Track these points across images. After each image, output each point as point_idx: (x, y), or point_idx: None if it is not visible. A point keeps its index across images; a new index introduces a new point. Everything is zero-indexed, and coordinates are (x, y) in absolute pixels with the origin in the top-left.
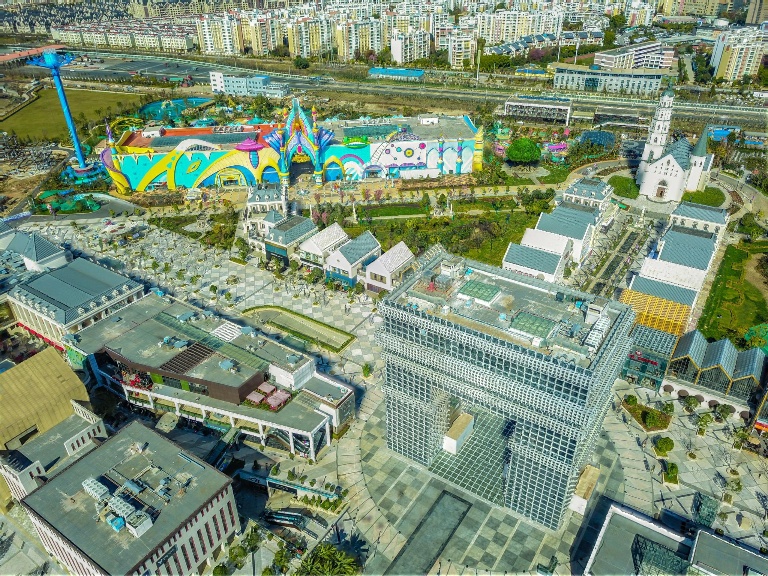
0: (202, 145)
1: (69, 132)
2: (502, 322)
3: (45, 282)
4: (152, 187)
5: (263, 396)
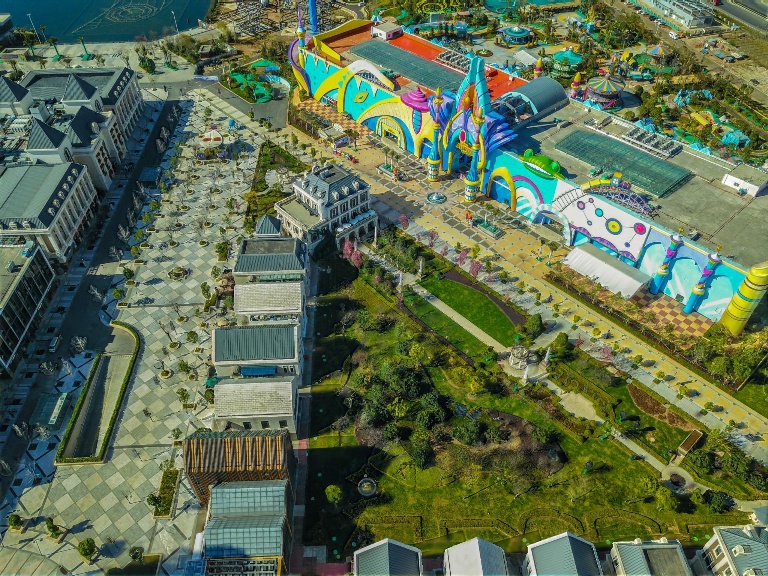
0: (374, 74)
1: (306, 1)
2: None
3: (14, 174)
4: (326, 101)
5: None
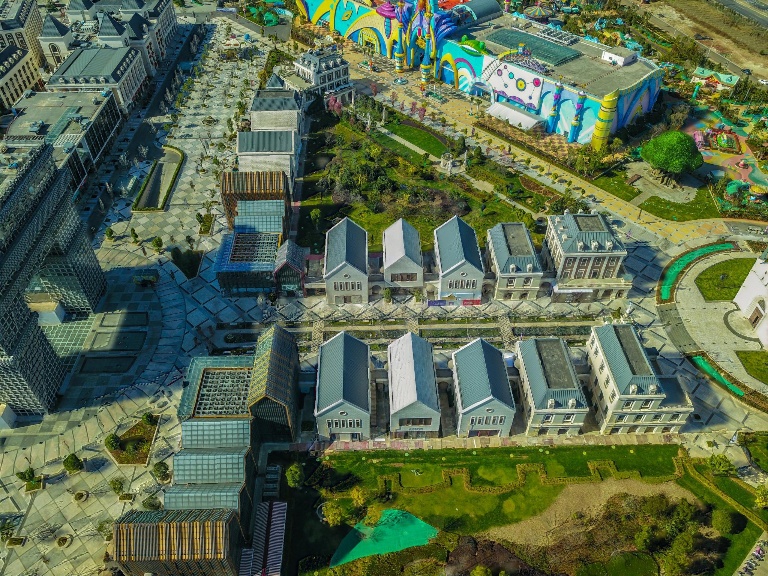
0: None
1: None
2: None
3: (90, 53)
4: (321, 23)
5: None
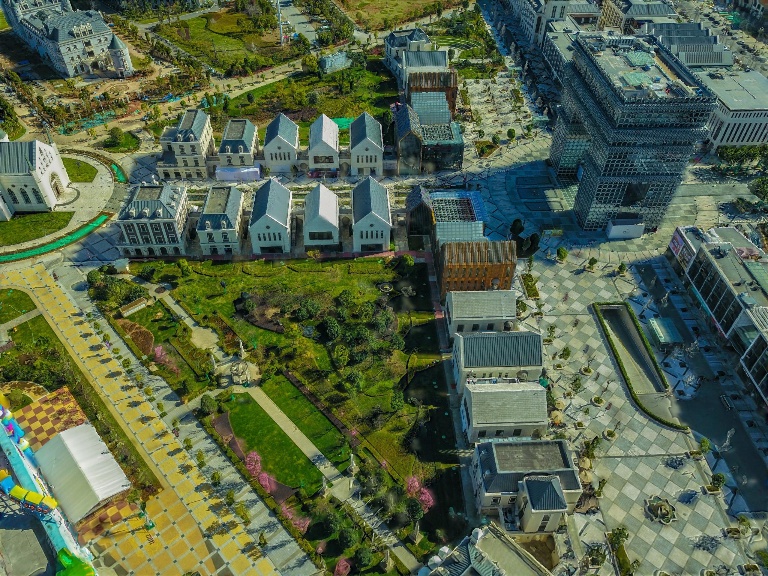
0: None
1: None
2: (651, 69)
3: None
4: None
5: (760, 259)
